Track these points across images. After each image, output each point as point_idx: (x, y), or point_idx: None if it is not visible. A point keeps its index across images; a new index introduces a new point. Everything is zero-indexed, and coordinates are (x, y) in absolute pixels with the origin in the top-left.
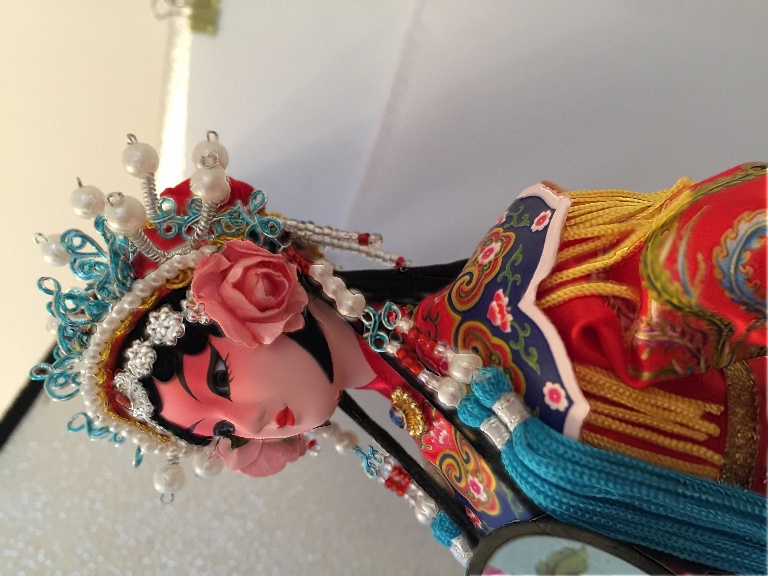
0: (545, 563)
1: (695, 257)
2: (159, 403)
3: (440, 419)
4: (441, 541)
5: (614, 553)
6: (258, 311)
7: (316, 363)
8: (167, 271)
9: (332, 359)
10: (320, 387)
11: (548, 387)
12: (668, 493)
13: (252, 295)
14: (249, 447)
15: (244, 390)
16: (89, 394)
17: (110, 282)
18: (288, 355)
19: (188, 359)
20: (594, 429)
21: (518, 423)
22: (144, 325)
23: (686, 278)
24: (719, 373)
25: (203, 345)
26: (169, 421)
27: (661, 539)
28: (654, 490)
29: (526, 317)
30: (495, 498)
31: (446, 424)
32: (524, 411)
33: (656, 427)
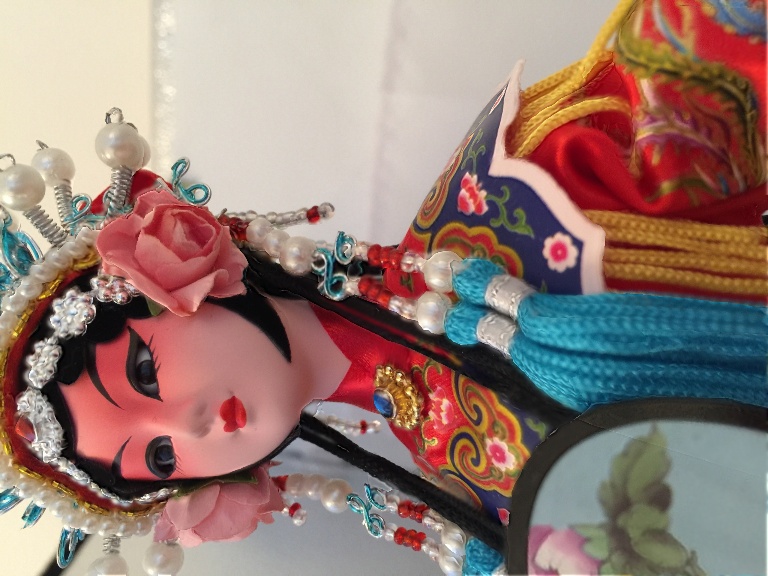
0: (610, 484)
1: (673, 7)
2: (70, 423)
3: (436, 385)
4: None
5: (702, 418)
6: (179, 260)
7: (266, 338)
8: (74, 249)
9: (287, 335)
10: (275, 367)
11: (548, 246)
12: (751, 327)
13: (170, 243)
14: (203, 497)
15: (175, 379)
16: None
17: (10, 282)
18: (228, 328)
19: (102, 350)
20: (624, 284)
21: (521, 299)
22: (48, 321)
23: (671, 33)
24: None
25: (119, 328)
26: (89, 457)
27: (767, 405)
28: (730, 325)
29: (500, 179)
30: (526, 453)
31: (444, 388)
32: (526, 286)
33: (706, 268)
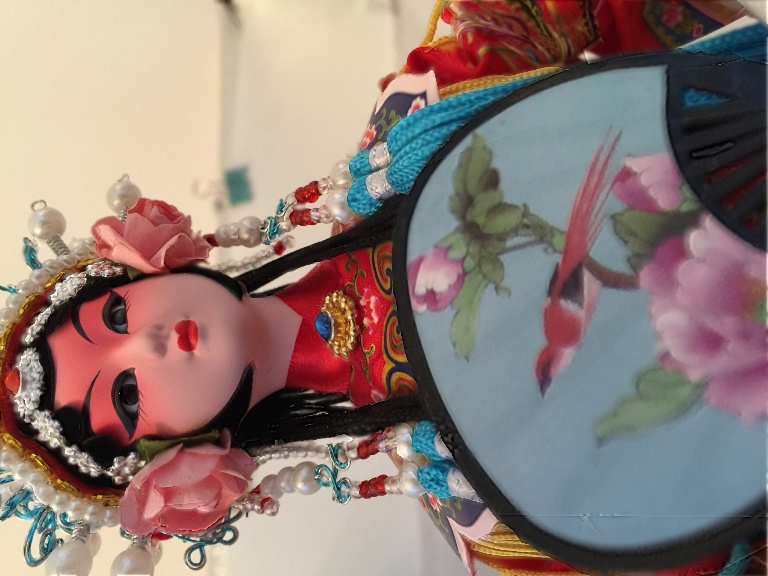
0: (455, 195)
1: None
2: (51, 367)
3: (363, 289)
4: (436, 485)
5: (502, 109)
6: (152, 225)
7: (222, 287)
8: (79, 254)
9: (242, 288)
10: (227, 302)
11: None
12: None
13: None
14: (166, 454)
15: (141, 312)
16: None
17: None
18: (190, 279)
19: (86, 305)
20: None
21: None
22: (50, 301)
23: None
24: None
25: (103, 288)
26: (63, 405)
27: None
28: None
29: None
30: None
31: (370, 287)
32: None
33: None
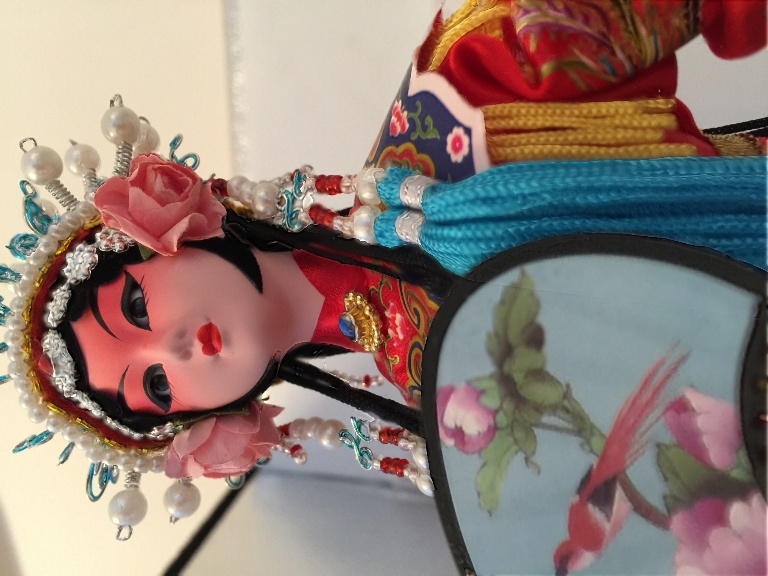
0: (494, 334)
1: None
2: (80, 356)
3: (389, 301)
4: None
5: (559, 253)
6: (158, 205)
7: (241, 273)
8: (84, 212)
9: (261, 271)
10: (247, 297)
11: (449, 142)
12: None
13: (152, 192)
14: (201, 428)
15: (160, 309)
16: (18, 376)
17: None
18: (206, 265)
19: (103, 291)
20: None
21: (424, 189)
22: (63, 272)
23: None
24: (701, 140)
25: (117, 271)
26: (99, 389)
27: None
28: None
29: (415, 96)
30: None
31: (396, 303)
32: (431, 180)
33: (594, 142)
